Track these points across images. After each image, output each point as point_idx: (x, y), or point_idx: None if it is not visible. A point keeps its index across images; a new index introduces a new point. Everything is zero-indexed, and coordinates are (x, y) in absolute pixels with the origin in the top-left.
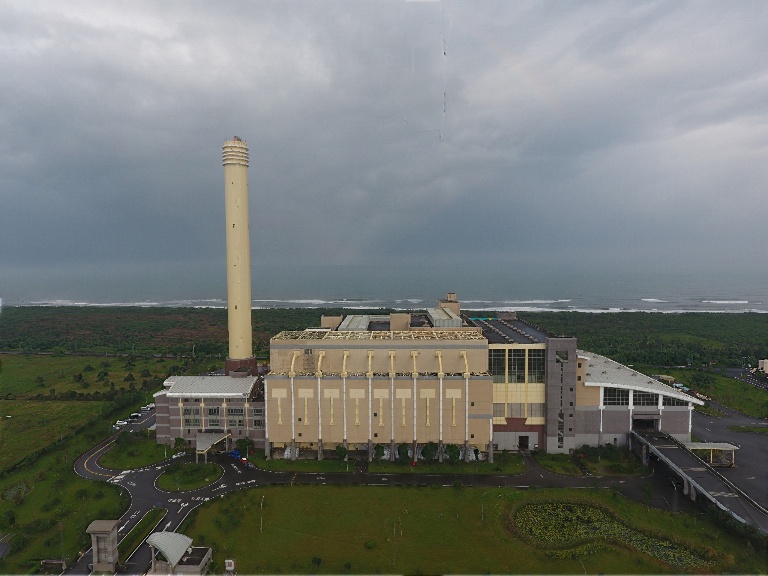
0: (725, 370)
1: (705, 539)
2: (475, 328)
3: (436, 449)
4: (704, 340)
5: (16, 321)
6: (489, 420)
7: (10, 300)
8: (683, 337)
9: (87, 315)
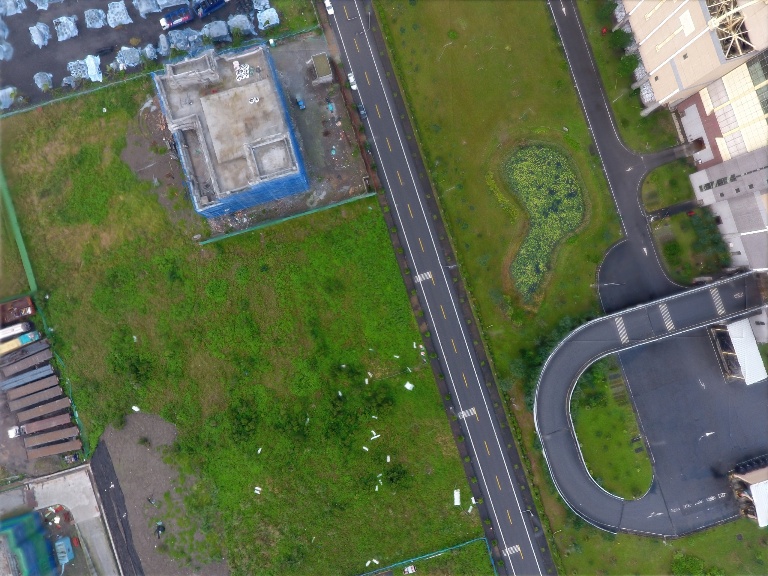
0: None
1: None
2: None
3: (624, 45)
4: None
5: None
6: (677, 88)
7: None
8: None
9: None
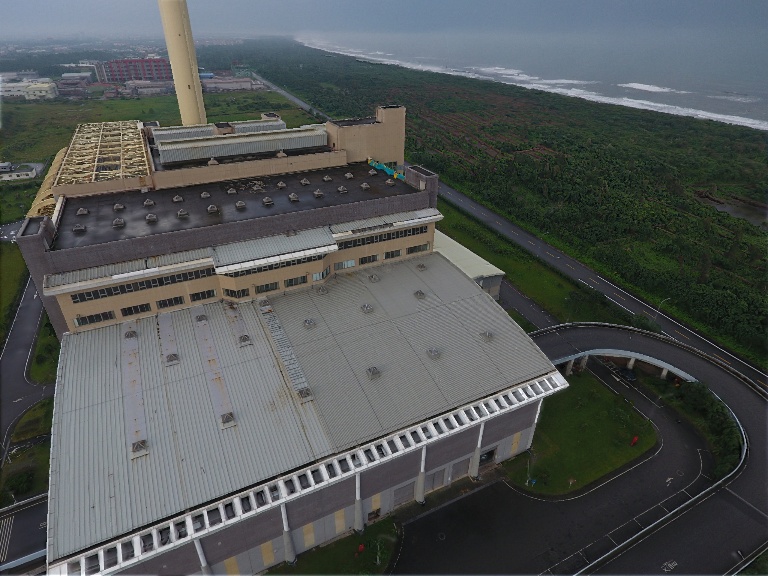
0: None
1: None
2: None
3: None
4: None
5: (396, 85)
6: None
7: (438, 65)
8: None
9: (451, 87)
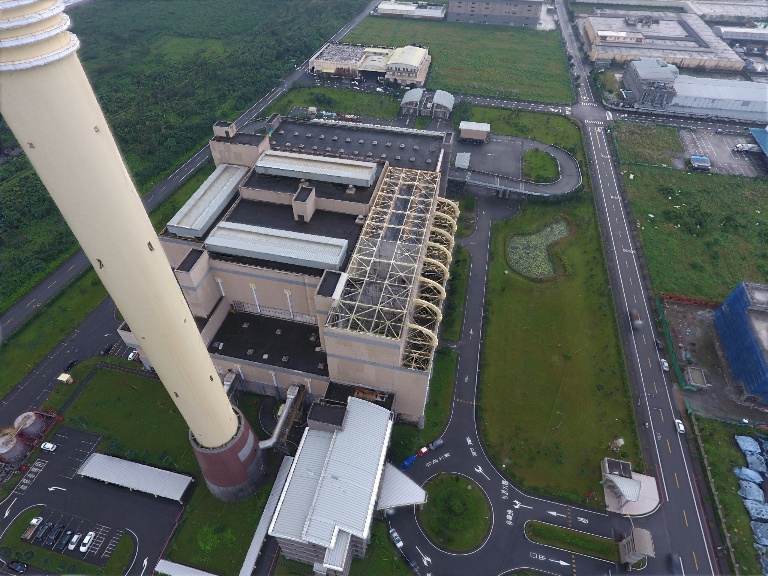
0: (314, 82)
1: (547, 214)
2: (386, 165)
3: None
4: (200, 42)
5: None
6: None
7: None
8: (178, 43)
9: None
